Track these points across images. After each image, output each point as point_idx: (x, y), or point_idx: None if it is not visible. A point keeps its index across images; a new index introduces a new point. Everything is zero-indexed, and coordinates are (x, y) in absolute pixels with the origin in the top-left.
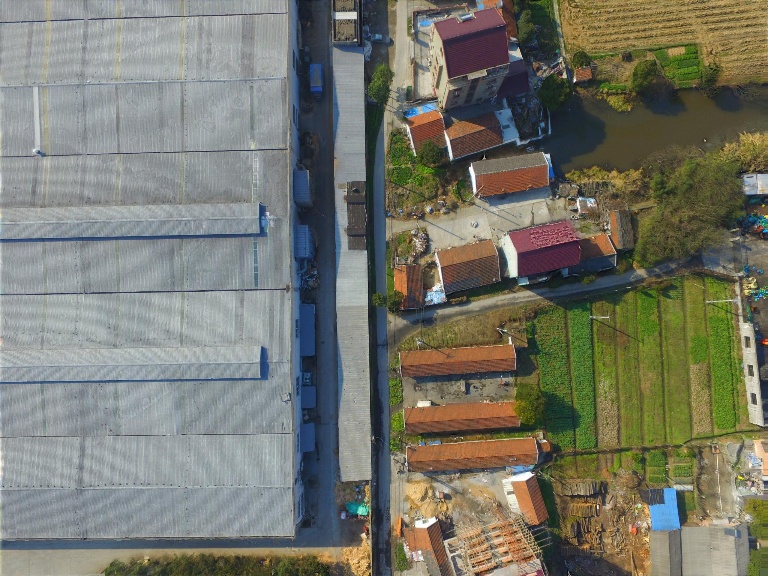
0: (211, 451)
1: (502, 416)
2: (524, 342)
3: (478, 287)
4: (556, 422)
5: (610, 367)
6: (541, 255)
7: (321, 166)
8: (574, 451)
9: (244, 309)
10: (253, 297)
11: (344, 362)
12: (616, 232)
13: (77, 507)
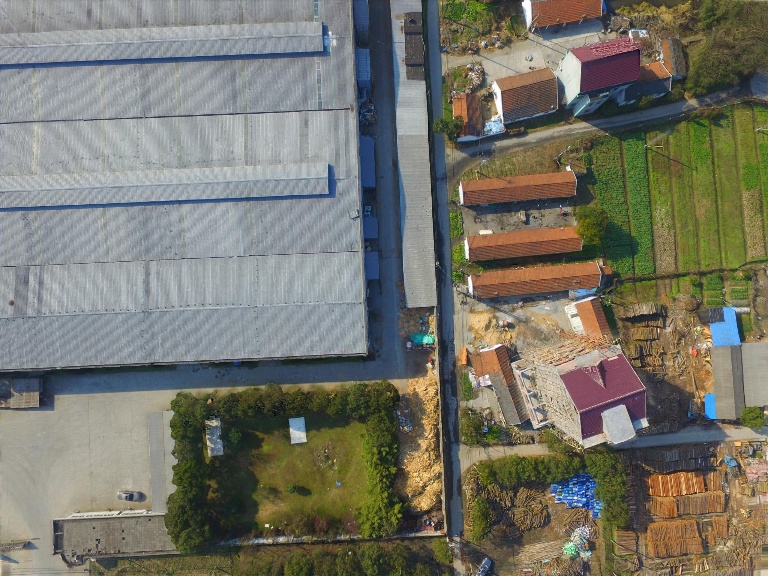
0: (280, 271)
1: (565, 238)
2: (583, 168)
3: (535, 119)
4: (615, 249)
5: (666, 195)
6: (604, 65)
7: (375, 3)
8: (633, 278)
9: (309, 129)
10: (317, 117)
11: (406, 190)
12: (669, 59)
13: (144, 331)
